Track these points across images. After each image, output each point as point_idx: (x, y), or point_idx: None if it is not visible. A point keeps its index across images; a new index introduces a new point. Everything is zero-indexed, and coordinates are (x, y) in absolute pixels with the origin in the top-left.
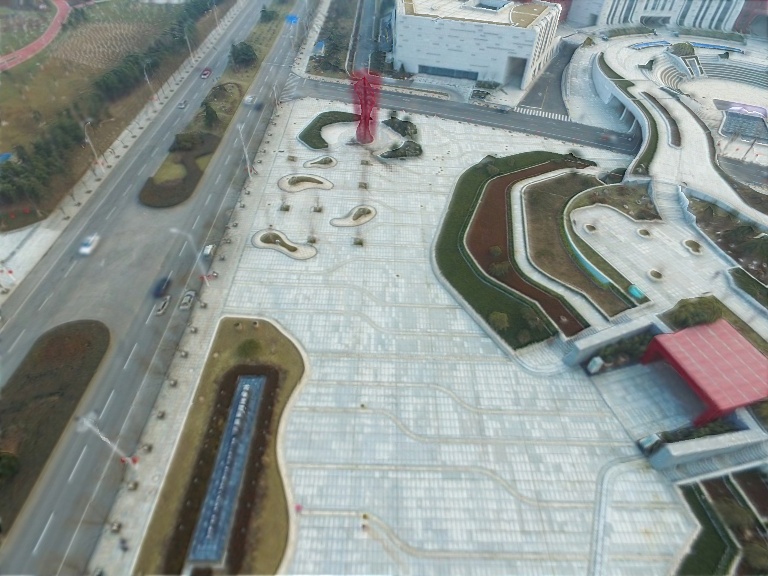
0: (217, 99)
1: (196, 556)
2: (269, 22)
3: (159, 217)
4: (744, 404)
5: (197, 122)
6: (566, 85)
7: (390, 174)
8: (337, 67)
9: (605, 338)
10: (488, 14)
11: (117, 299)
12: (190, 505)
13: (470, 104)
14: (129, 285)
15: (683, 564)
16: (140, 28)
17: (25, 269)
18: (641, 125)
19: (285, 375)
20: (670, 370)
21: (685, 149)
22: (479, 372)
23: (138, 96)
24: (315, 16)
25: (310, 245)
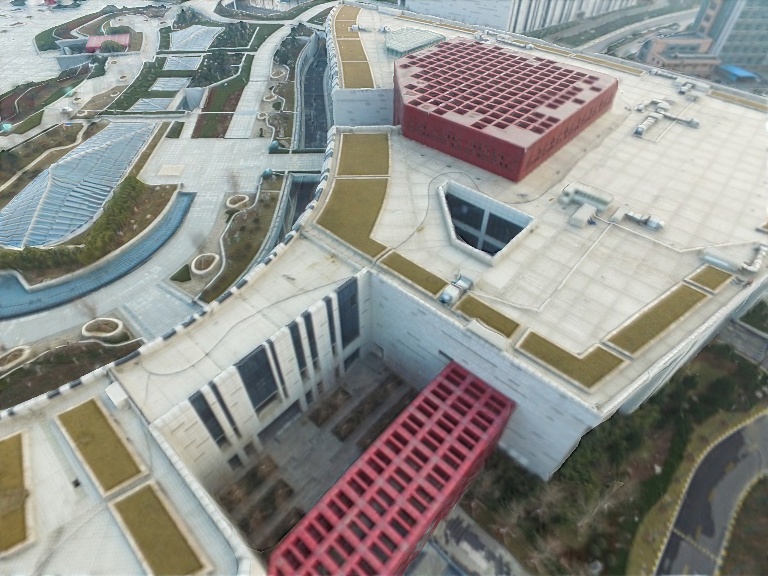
0: None
1: None
2: None
3: None
4: (99, 47)
5: None
6: None
7: (50, 14)
8: None
9: (72, 40)
10: None
11: None
12: None
13: None
14: None
15: None
16: None
17: None
18: None
19: None
20: None
21: None
22: None
23: None
24: None
25: None
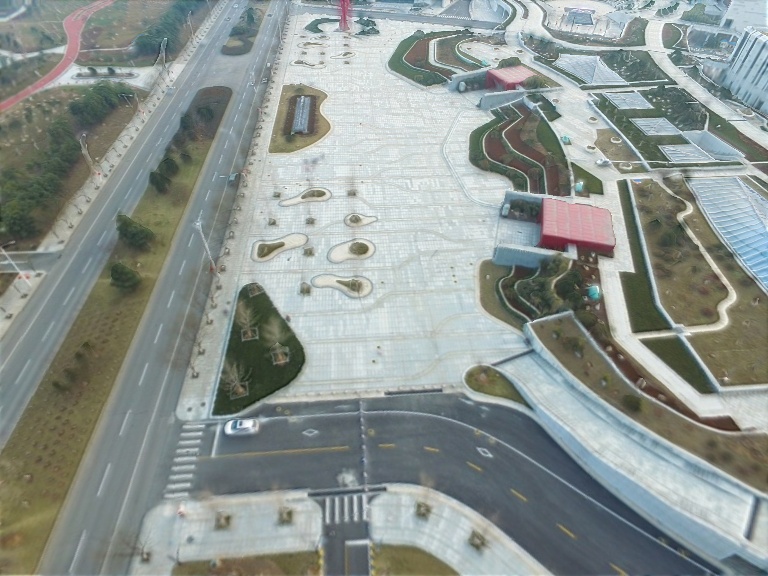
0: None
1: (296, 129)
2: None
3: (236, 58)
4: (519, 83)
5: (241, 24)
6: (471, 4)
7: (361, 41)
8: None
9: (466, 74)
10: None
11: (229, 82)
12: (289, 121)
13: (409, 14)
14: (232, 78)
15: (486, 124)
16: None
17: (176, 75)
18: None
19: (319, 97)
20: (497, 88)
21: (529, 20)
22: (409, 94)
23: (199, 15)
24: None
25: (321, 64)
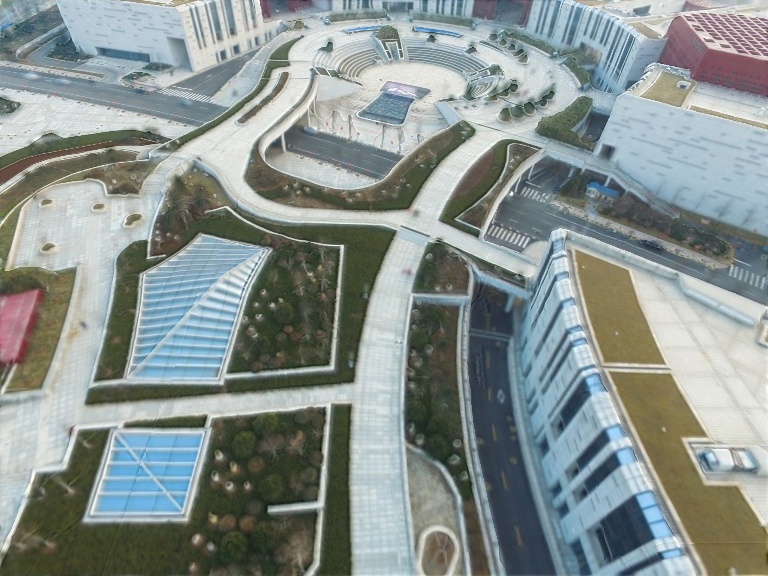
0: None
1: None
2: None
3: None
4: None
5: None
6: None
7: None
8: (5, 48)
9: None
10: None
11: None
12: None
13: (116, 85)
14: None
15: None
16: None
17: None
18: None
19: None
20: None
21: (247, 126)
22: None
23: None
24: None
25: None
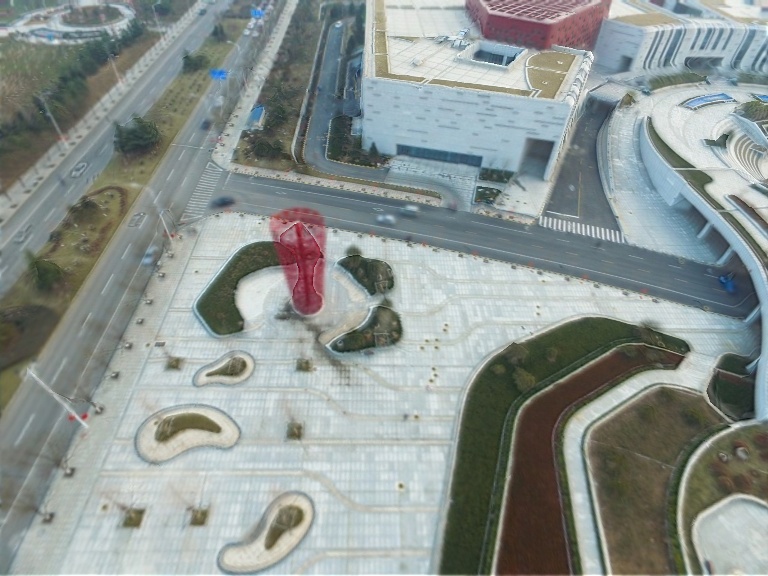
0: (78, 224)
1: None
2: (194, 73)
3: None
4: None
5: (28, 280)
6: (607, 172)
7: (345, 393)
8: (279, 150)
9: None
10: (494, 72)
11: None
12: None
13: (473, 213)
14: None
15: None
16: (9, 86)
17: None
18: (748, 267)
19: None
20: None
21: None
22: None
23: None
24: (260, 61)
25: None
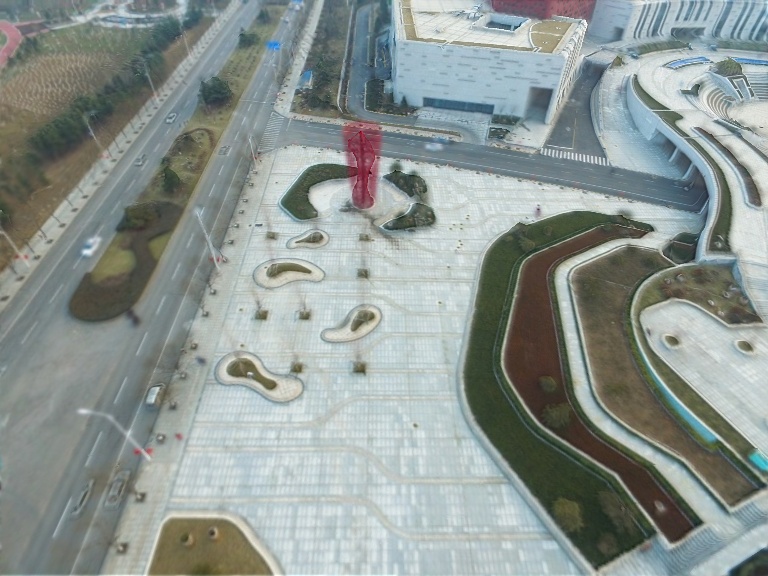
0: (182, 152)
1: None
2: (249, 47)
3: (93, 337)
4: None
5: (155, 186)
6: (598, 117)
7: (397, 253)
8: (327, 103)
9: (736, 560)
10: (503, 36)
11: (17, 490)
12: None
13: (487, 146)
14: (37, 462)
15: None
16: (99, 60)
17: None
18: (703, 174)
19: None
20: None
21: (767, 210)
22: None
23: (85, 152)
24: (302, 38)
25: (294, 376)
